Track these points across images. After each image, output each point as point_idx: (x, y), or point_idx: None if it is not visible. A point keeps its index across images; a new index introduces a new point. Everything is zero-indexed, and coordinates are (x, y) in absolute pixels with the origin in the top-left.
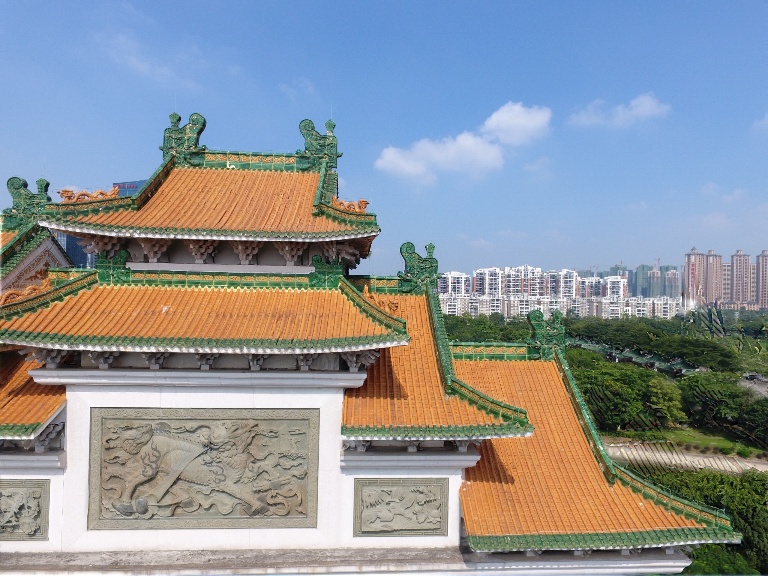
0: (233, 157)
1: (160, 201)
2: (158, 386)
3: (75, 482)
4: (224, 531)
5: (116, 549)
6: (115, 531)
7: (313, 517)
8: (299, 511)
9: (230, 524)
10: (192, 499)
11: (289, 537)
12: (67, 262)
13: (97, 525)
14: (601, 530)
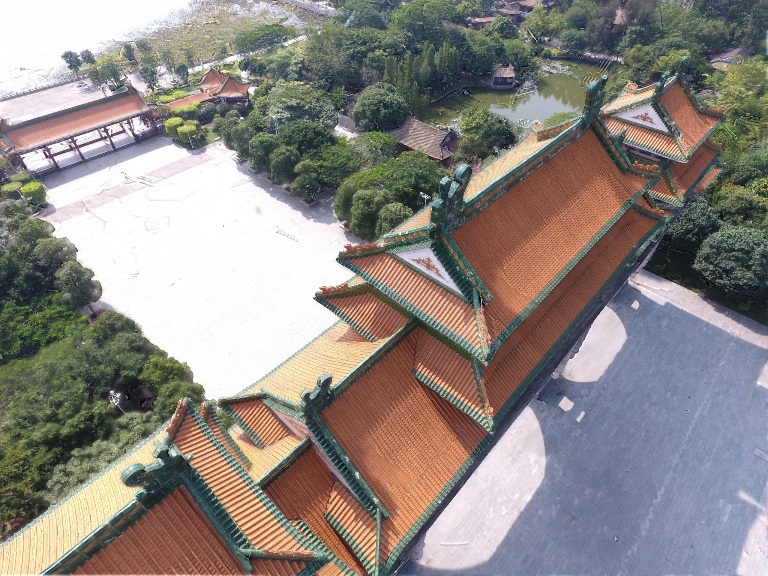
0: None
1: None
2: None
3: None
4: None
5: None
6: None
7: None
8: None
9: None
10: None
11: None
12: (325, 451)
13: None
14: None
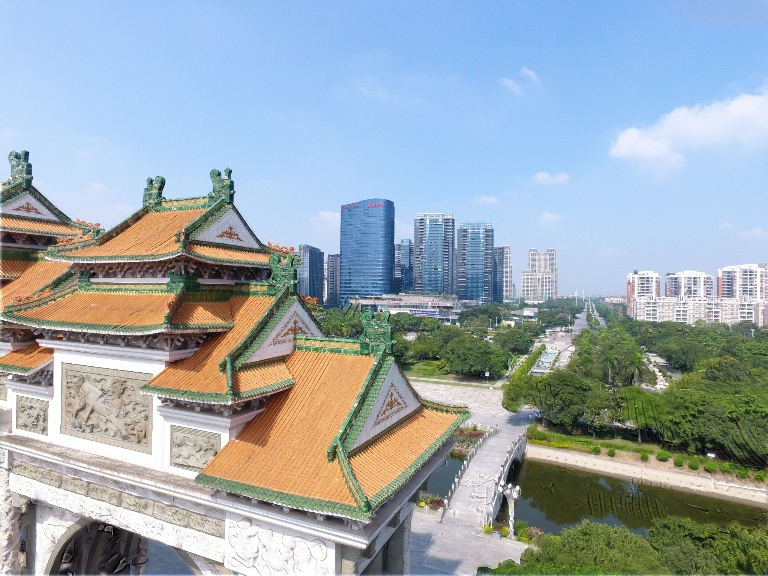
0: (175, 203)
1: (117, 238)
2: (85, 352)
3: (56, 405)
4: (111, 447)
5: (70, 447)
6: (70, 436)
7: (151, 447)
8: (144, 441)
9: (114, 443)
10: (99, 424)
11: (139, 458)
12: None
13: (64, 431)
14: (284, 490)
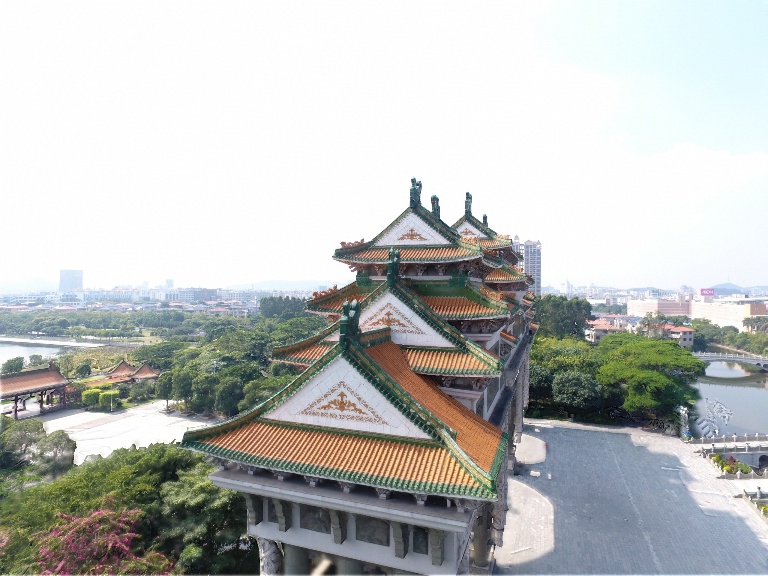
0: None
1: None
2: None
3: None
4: None
5: None
6: None
7: None
8: None
9: None
10: None
11: None
12: None
13: None
14: None
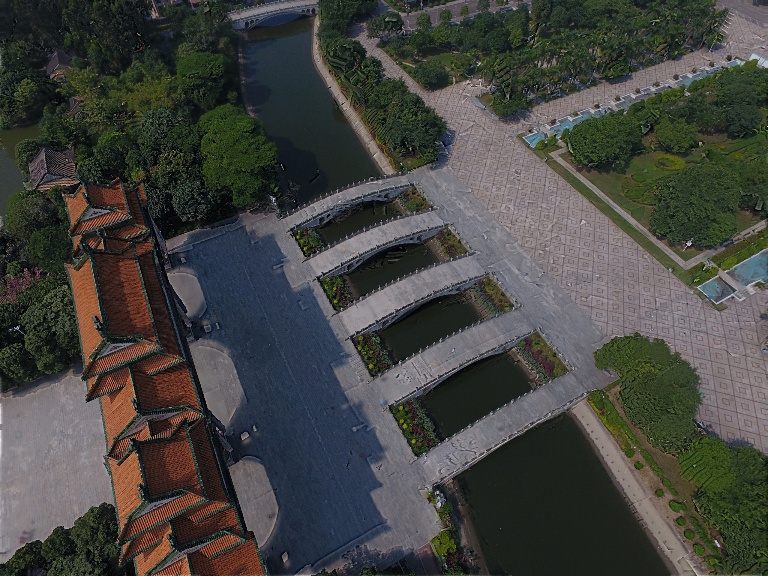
0: None
1: None
2: None
3: None
4: None
5: None
6: None
7: None
8: None
9: None
10: None
11: None
12: None
13: None
14: None
